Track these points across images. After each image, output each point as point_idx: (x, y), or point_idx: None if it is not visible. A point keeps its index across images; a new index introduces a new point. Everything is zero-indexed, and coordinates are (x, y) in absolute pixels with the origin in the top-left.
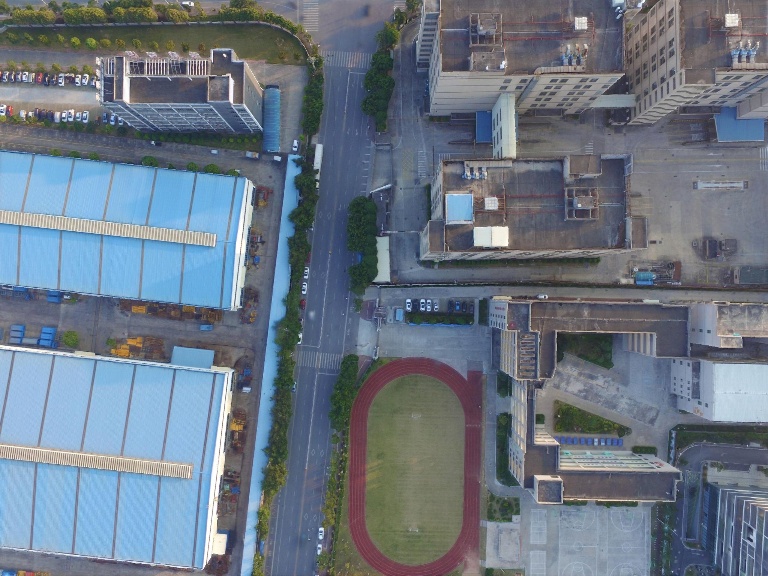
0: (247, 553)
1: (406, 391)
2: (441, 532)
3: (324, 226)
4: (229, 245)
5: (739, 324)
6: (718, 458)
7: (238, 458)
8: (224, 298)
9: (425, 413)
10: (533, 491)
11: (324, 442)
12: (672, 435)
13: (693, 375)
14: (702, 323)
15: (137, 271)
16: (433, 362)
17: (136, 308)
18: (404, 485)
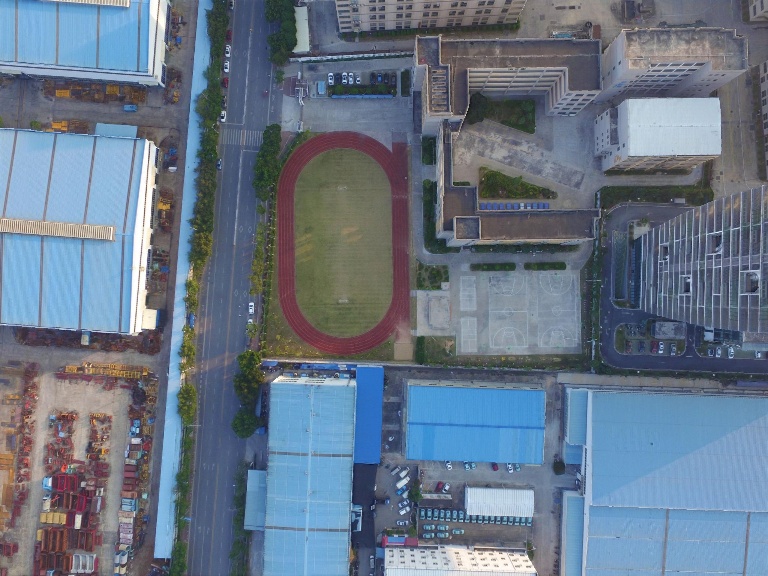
0: (177, 325)
1: (332, 165)
2: (371, 304)
3: (244, 5)
4: (143, 5)
5: (648, 51)
6: (644, 217)
7: (166, 237)
8: (141, 61)
9: (351, 186)
10: (453, 234)
11: (252, 218)
12: (597, 196)
13: (611, 121)
14: (614, 59)
15: (53, 36)
16: (357, 135)
17: (60, 92)
18: (333, 258)
